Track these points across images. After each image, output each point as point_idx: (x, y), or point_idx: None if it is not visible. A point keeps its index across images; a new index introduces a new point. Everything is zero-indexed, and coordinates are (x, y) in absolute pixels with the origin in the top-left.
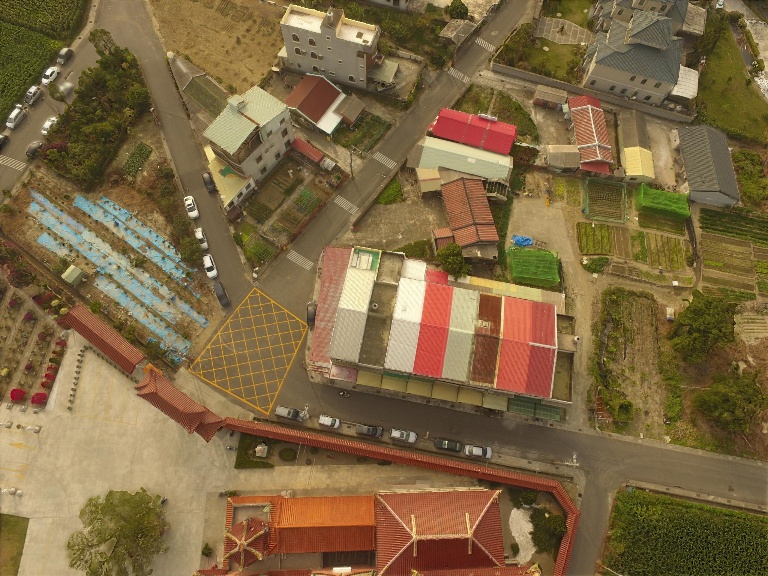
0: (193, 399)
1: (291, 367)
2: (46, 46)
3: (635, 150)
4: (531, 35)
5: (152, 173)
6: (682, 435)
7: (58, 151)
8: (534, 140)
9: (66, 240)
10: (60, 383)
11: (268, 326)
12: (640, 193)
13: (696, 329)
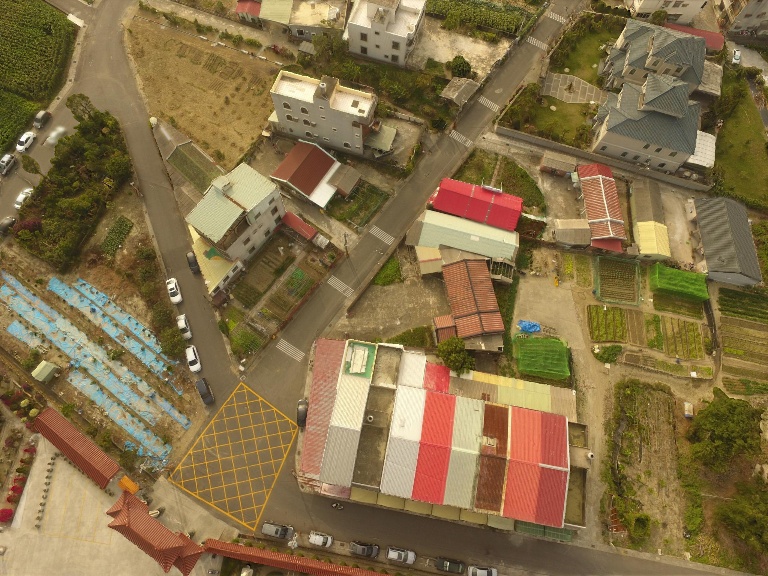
0: (173, 514)
1: (280, 475)
2: (22, 109)
3: (649, 225)
4: (537, 94)
5: (133, 251)
6: (703, 551)
7: (31, 229)
8: (541, 211)
9: (38, 329)
10: (28, 496)
11: (255, 427)
12: (655, 273)
13: (718, 436)
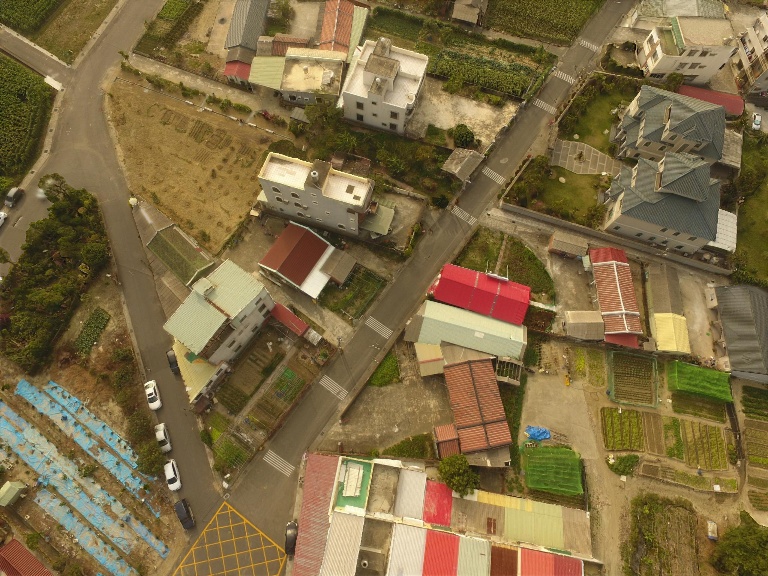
0: None
1: None
2: None
3: (667, 318)
4: (545, 165)
5: (109, 348)
6: None
7: None
8: (550, 299)
9: (4, 440)
10: None
11: (239, 555)
12: (674, 371)
13: (747, 571)
